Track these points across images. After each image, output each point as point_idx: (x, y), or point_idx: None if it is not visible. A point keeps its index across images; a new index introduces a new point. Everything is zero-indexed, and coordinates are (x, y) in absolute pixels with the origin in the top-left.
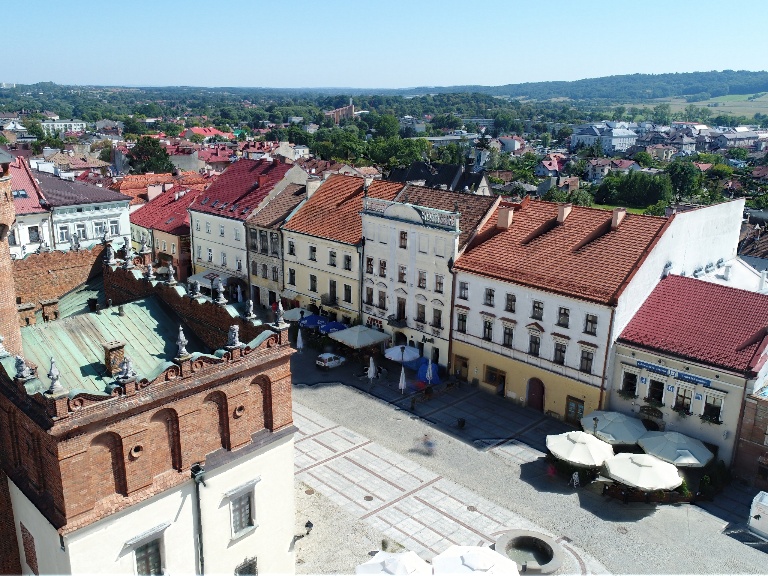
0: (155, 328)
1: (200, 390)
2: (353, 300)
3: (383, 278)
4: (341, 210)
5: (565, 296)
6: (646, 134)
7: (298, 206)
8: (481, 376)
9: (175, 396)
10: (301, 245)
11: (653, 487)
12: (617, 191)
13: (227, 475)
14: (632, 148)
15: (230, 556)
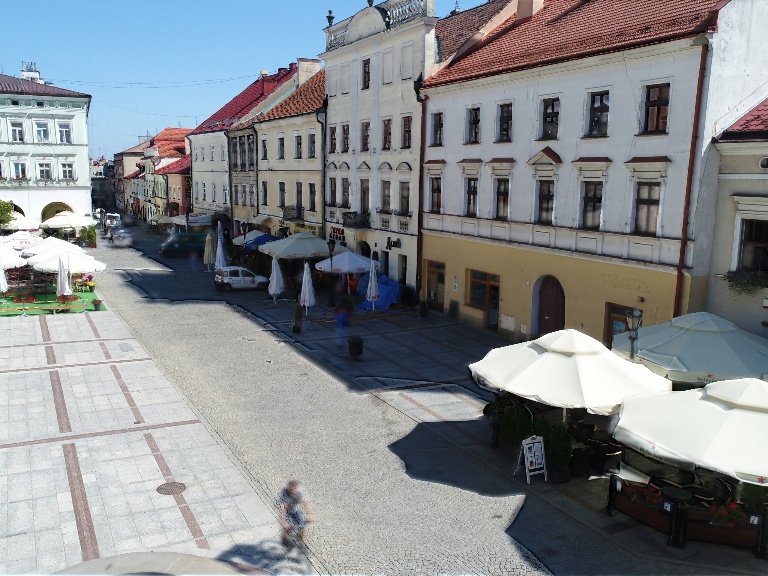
0: None
1: None
2: (317, 206)
3: (345, 154)
4: None
5: (596, 54)
6: None
7: (283, 95)
8: (461, 294)
9: None
10: (271, 141)
11: (764, 476)
12: None
13: None
14: None
15: None
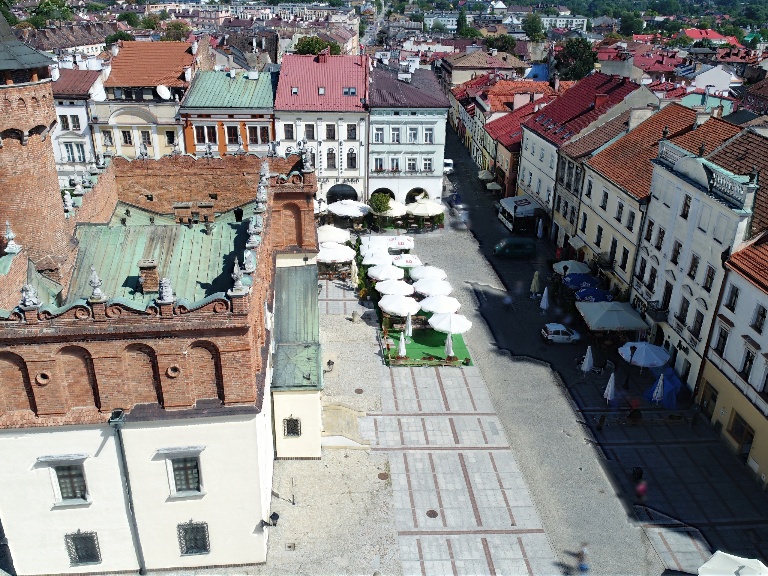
0: (226, 255)
1: (119, 337)
2: (627, 268)
3: (657, 251)
4: (652, 152)
5: None
6: None
7: (613, 139)
8: (726, 422)
9: (86, 336)
10: (597, 187)
11: None
12: None
13: (160, 432)
14: None
15: (170, 510)
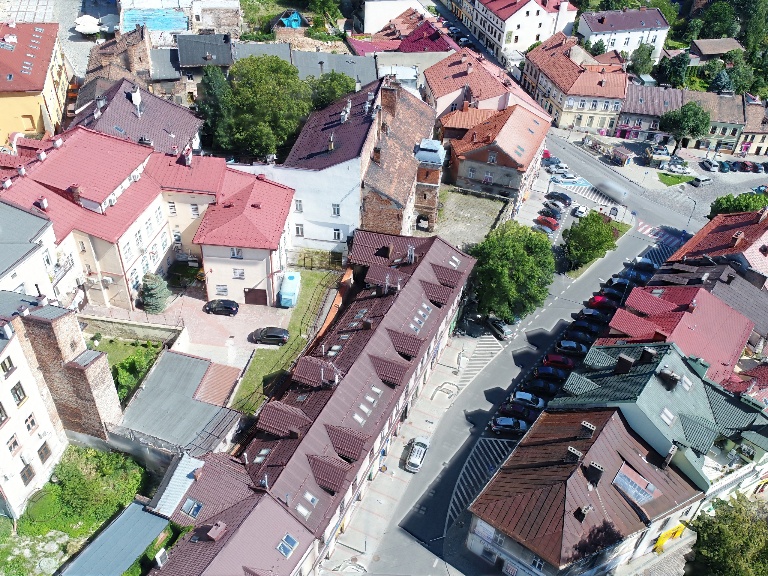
0: None
1: None
2: None
3: None
4: None
5: None
6: None
7: None
8: None
9: None
10: None
11: None
12: None
13: None
14: None
15: None
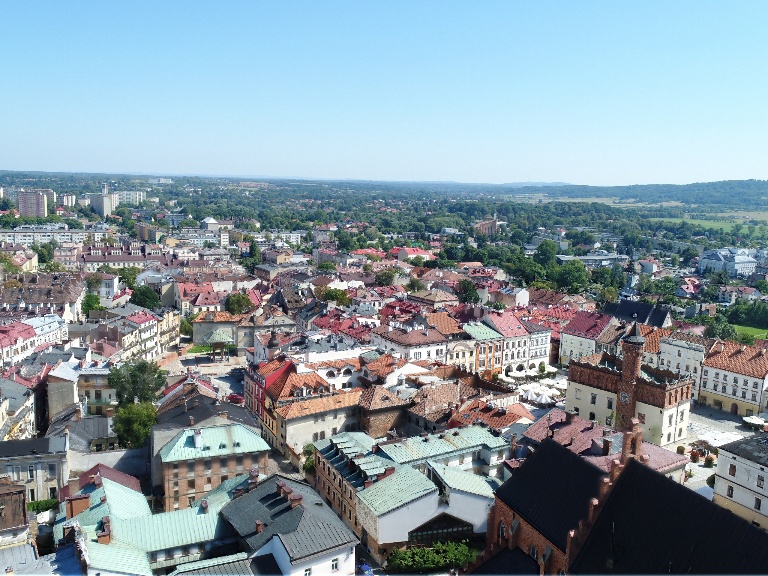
0: None
1: None
2: None
3: None
4: None
5: (747, 376)
6: (764, 262)
7: None
8: (712, 403)
9: None
10: None
11: None
12: (745, 315)
13: None
14: (753, 275)
15: None
